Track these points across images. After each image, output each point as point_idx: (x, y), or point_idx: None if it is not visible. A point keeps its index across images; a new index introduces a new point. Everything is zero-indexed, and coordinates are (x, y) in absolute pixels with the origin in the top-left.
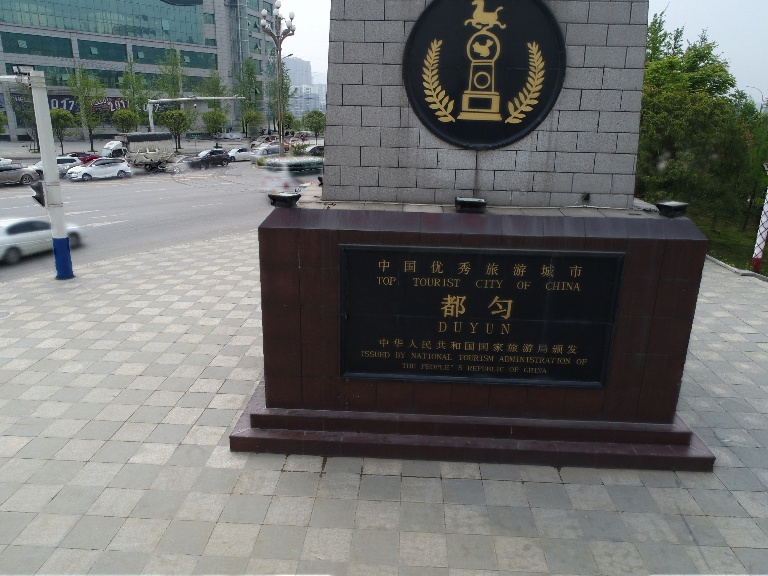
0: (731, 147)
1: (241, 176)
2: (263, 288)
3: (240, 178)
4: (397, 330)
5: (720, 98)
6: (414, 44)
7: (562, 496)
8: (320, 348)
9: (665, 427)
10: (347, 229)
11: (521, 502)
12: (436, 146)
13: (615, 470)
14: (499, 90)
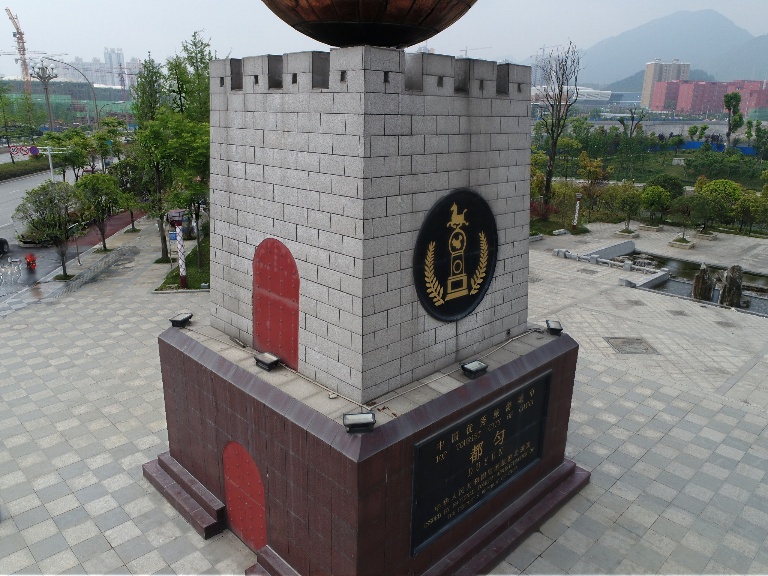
0: None
1: None
2: (359, 517)
3: None
4: (446, 492)
5: None
6: (419, 249)
7: (567, 551)
8: (398, 542)
9: (564, 467)
10: (420, 429)
11: (559, 572)
12: (434, 326)
13: (559, 512)
14: (466, 271)
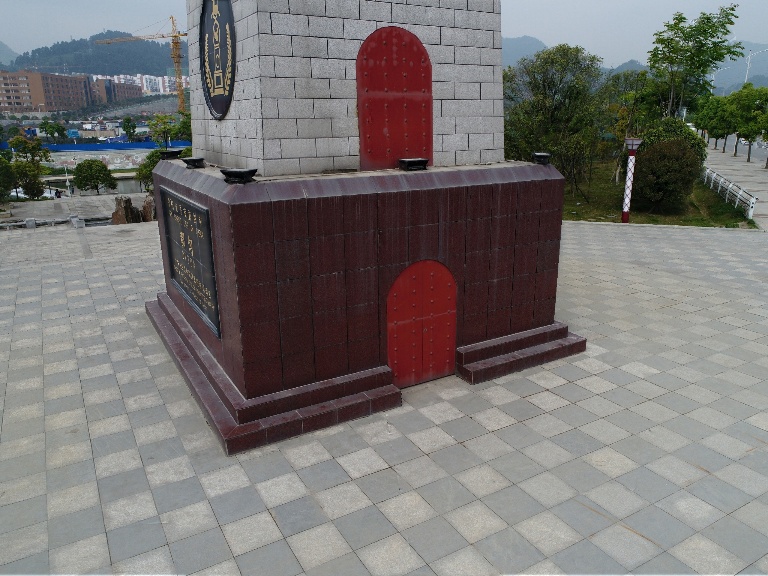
0: None
1: None
2: None
3: None
4: None
5: None
6: None
7: None
8: None
9: None
10: None
11: None
12: None
13: None
14: None
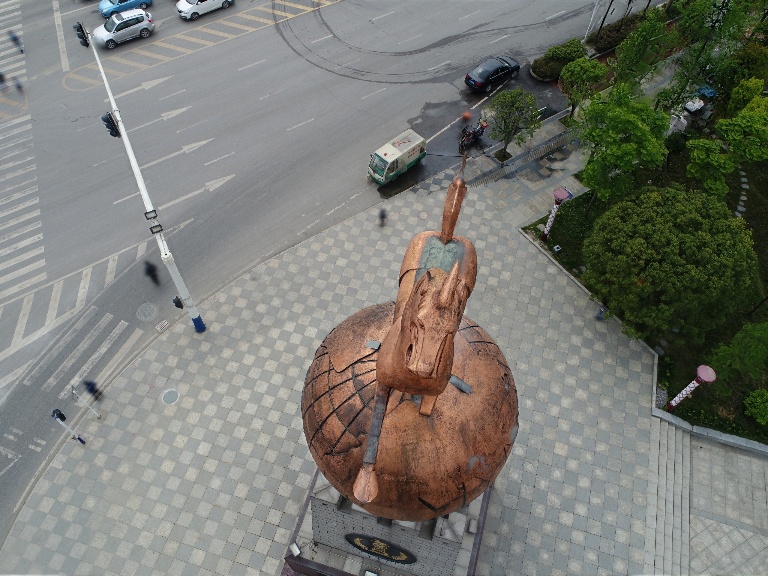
0: (718, 299)
1: (341, 1)
2: None
3: (339, 14)
4: None
5: (739, 248)
6: None
7: None
8: (312, 574)
9: None
10: (319, 570)
11: None
12: None
13: None
14: (388, 553)
